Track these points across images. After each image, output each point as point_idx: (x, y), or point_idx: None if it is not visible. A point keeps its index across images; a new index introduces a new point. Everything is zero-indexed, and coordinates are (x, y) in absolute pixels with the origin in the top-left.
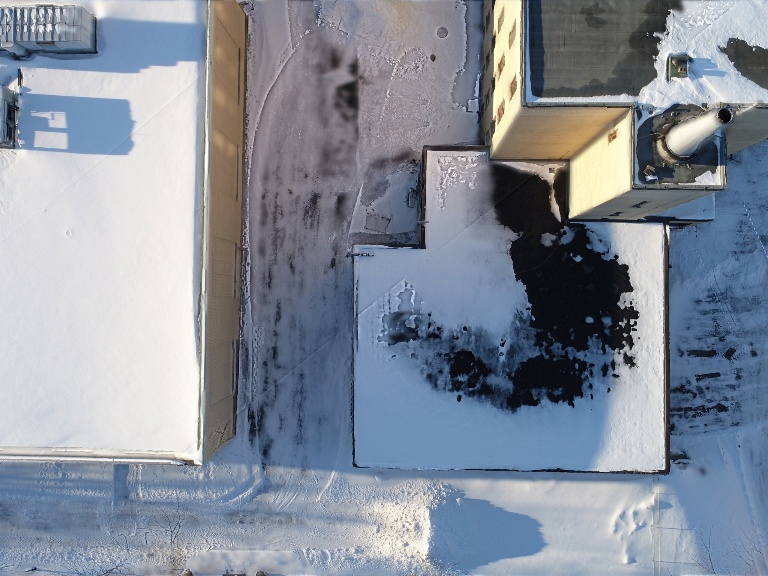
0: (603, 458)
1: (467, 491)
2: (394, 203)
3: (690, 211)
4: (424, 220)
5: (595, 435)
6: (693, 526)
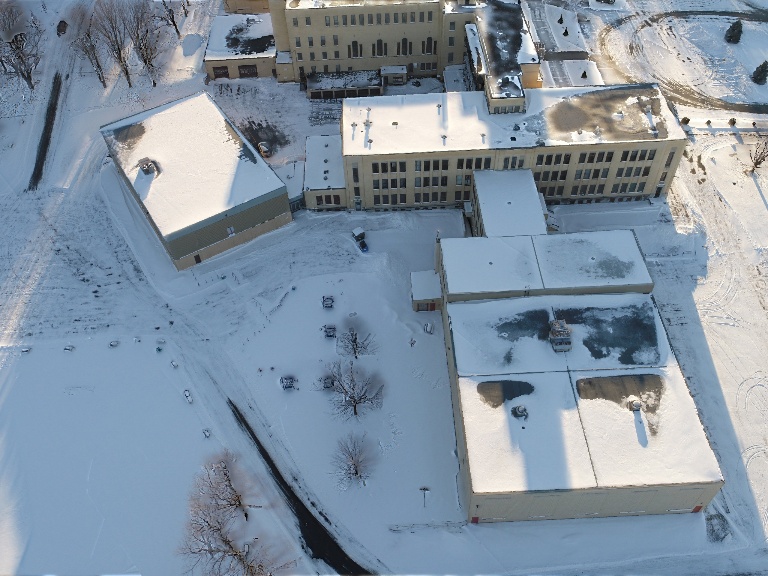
0: None
1: None
2: None
3: None
4: None
5: None
6: None
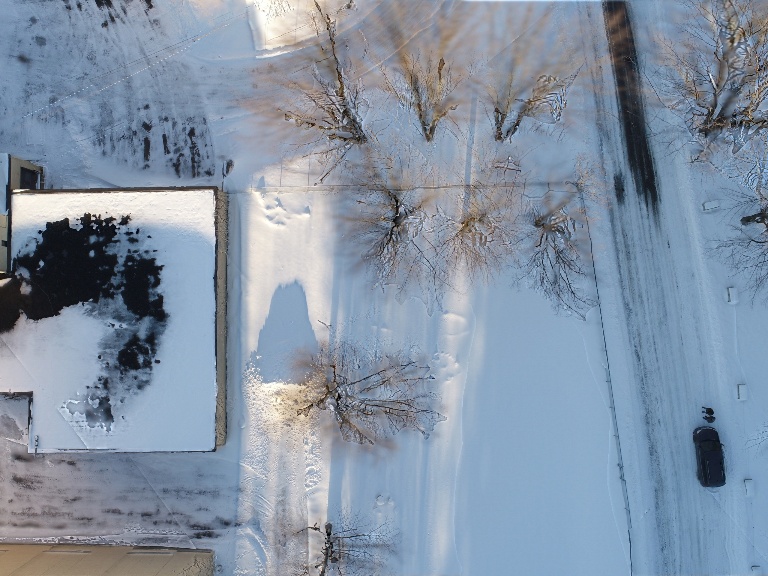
0: (205, 242)
1: (252, 350)
2: (20, 411)
3: (1, 174)
4: (8, 393)
5: (187, 248)
6: (280, 159)
